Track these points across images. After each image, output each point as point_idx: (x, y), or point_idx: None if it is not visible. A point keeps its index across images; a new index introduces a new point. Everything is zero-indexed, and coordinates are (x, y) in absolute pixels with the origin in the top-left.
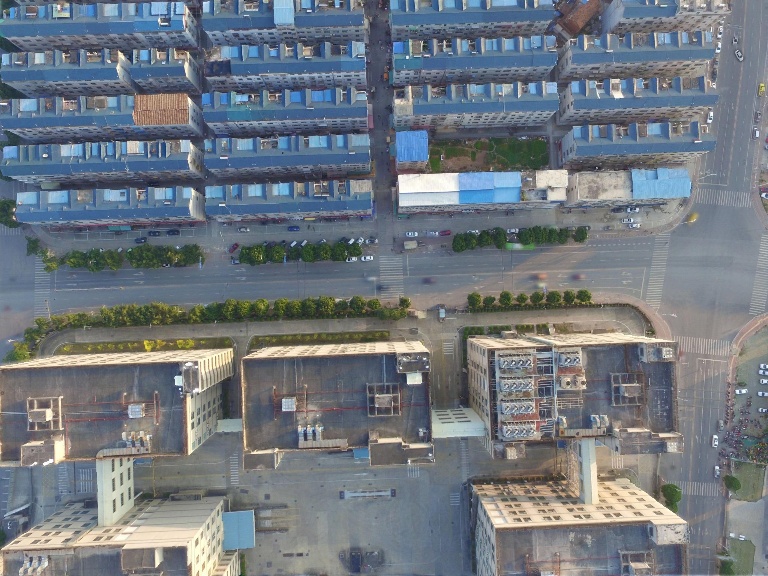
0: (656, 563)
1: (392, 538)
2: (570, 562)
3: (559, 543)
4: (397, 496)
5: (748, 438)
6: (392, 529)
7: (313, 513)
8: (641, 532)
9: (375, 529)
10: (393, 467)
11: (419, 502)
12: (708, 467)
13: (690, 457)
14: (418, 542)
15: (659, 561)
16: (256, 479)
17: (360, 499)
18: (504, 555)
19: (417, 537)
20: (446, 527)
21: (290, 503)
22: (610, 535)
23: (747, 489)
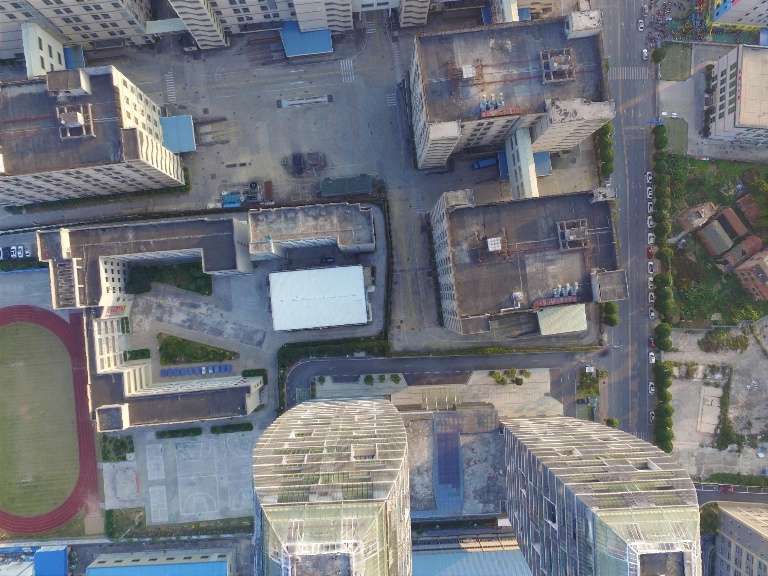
0: (576, 62)
1: (332, 142)
2: (492, 67)
3: (480, 50)
4: (334, 101)
5: (673, 21)
6: (332, 133)
7: (252, 124)
8: (559, 34)
9: (315, 134)
10: (328, 74)
11: (356, 105)
12: (636, 51)
13: (618, 43)
14: (358, 144)
15: (579, 60)
16: (193, 95)
17: (298, 107)
18: (427, 64)
19: (357, 139)
20: (385, 127)
21: (229, 116)
22: (529, 39)
23: (676, 69)
